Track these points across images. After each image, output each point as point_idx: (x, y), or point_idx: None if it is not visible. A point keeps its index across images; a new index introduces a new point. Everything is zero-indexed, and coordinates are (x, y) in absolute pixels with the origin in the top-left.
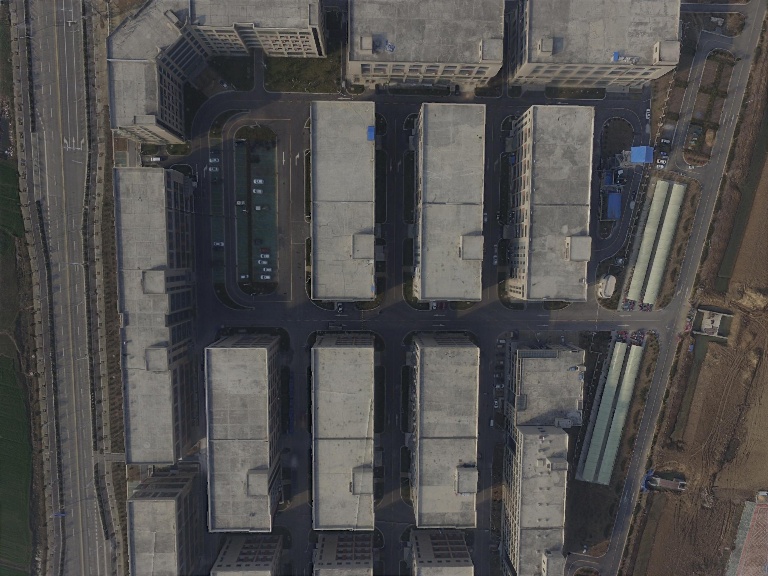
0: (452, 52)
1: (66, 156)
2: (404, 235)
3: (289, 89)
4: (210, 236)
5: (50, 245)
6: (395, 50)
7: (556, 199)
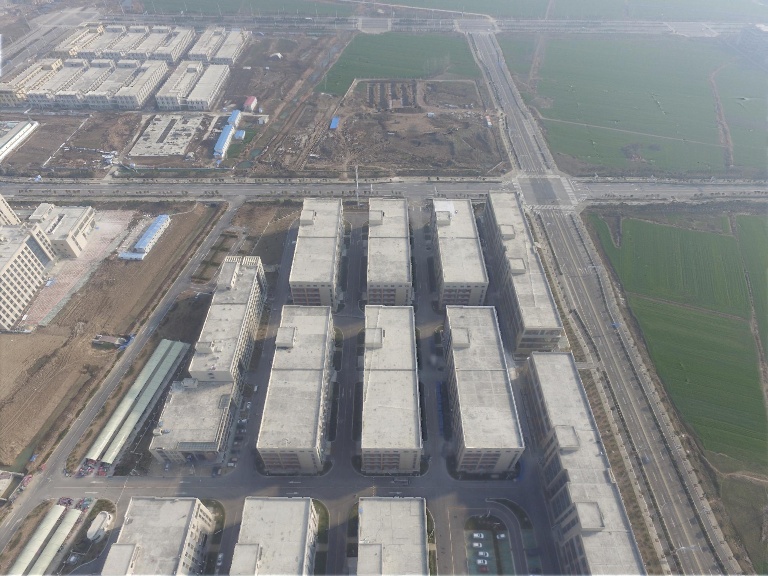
0: None
1: None
2: None
3: None
4: None
5: (721, 575)
6: None
7: None
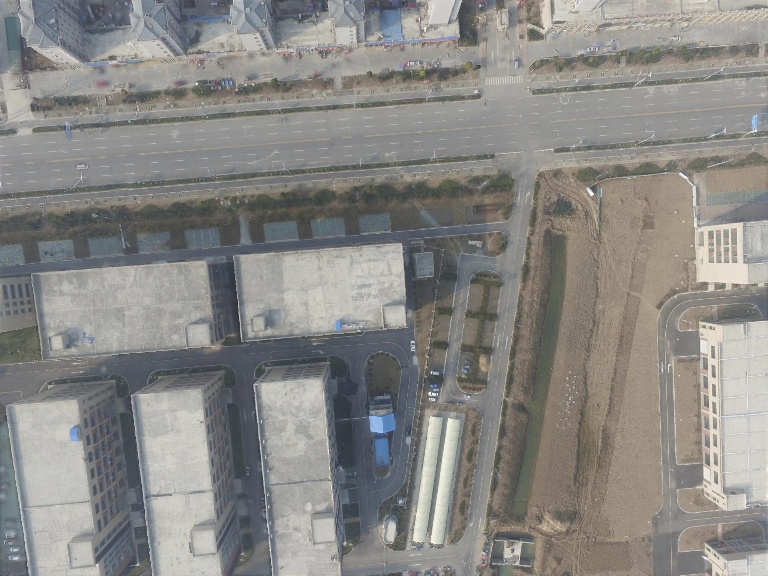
0: (158, 337)
1: None
2: None
3: (16, 360)
4: None
5: None
6: (95, 341)
7: (294, 477)
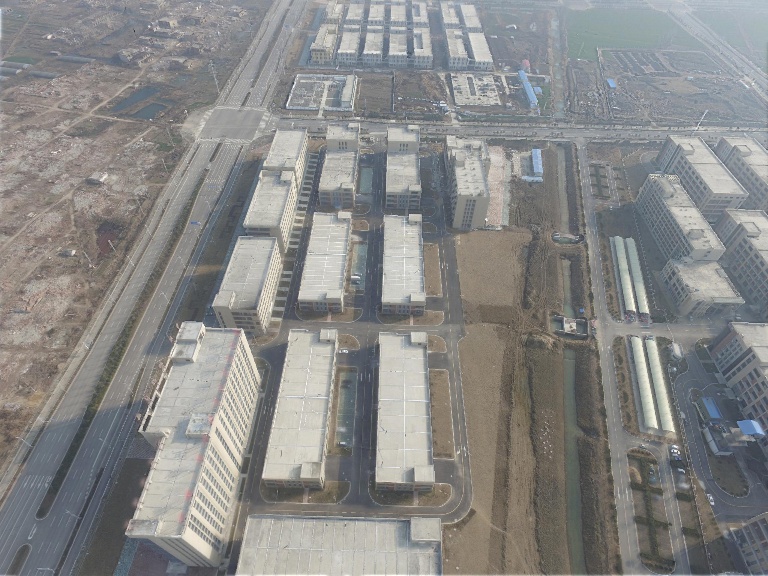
0: None
1: None
2: None
3: None
4: None
5: None
6: None
7: None
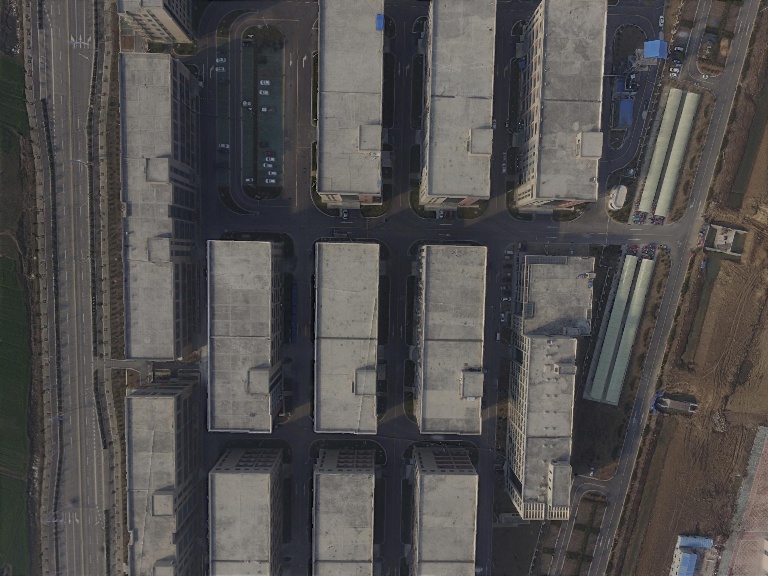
0: None
1: (73, 54)
2: (411, 141)
3: None
4: (215, 138)
5: (54, 144)
6: None
7: (567, 95)
